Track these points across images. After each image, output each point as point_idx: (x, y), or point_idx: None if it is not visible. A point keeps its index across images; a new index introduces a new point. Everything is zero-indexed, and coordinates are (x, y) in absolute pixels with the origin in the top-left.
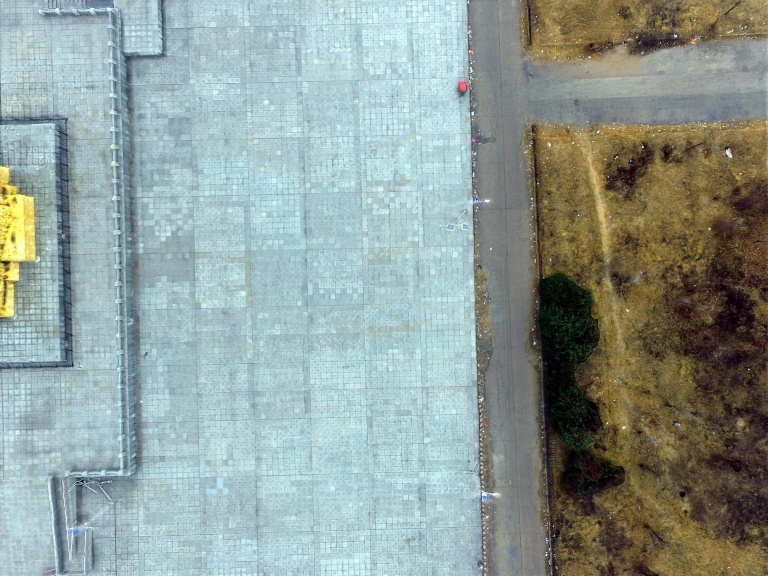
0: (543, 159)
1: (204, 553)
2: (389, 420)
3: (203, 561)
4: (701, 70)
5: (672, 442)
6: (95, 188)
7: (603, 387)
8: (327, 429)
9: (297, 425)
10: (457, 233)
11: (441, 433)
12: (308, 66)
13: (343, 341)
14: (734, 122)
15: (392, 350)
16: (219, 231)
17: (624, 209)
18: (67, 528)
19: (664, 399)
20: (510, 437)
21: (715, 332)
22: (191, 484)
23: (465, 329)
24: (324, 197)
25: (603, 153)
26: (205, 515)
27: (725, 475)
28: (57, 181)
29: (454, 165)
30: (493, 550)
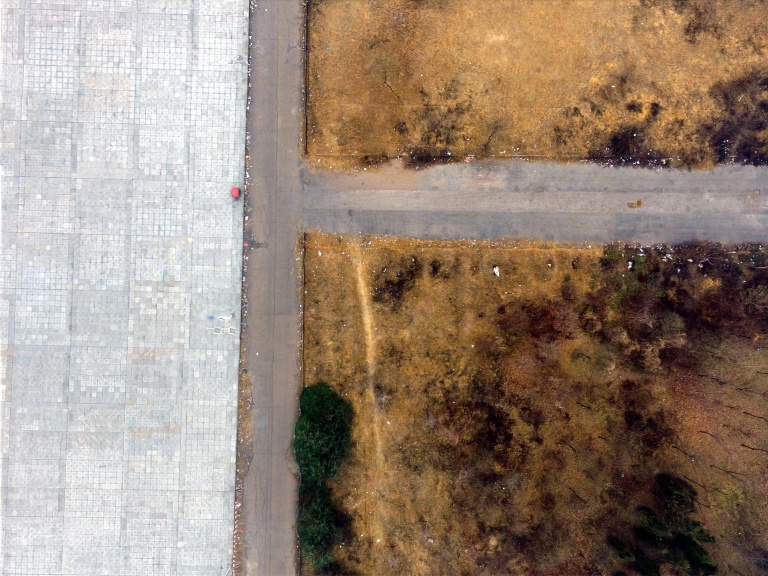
0: (312, 268)
1: None
2: (143, 522)
3: None
4: (474, 188)
5: (425, 558)
6: None
7: (360, 499)
8: (79, 529)
9: (49, 523)
10: (223, 337)
11: (195, 538)
12: (83, 163)
13: (102, 440)
14: (503, 241)
15: (151, 451)
16: None
17: (390, 322)
18: None
19: (420, 514)
20: (265, 545)
21: (473, 449)
22: None
23: (226, 434)
24: (91, 294)
25: (372, 265)
26: None
27: None
28: None
29: (224, 269)
30: None
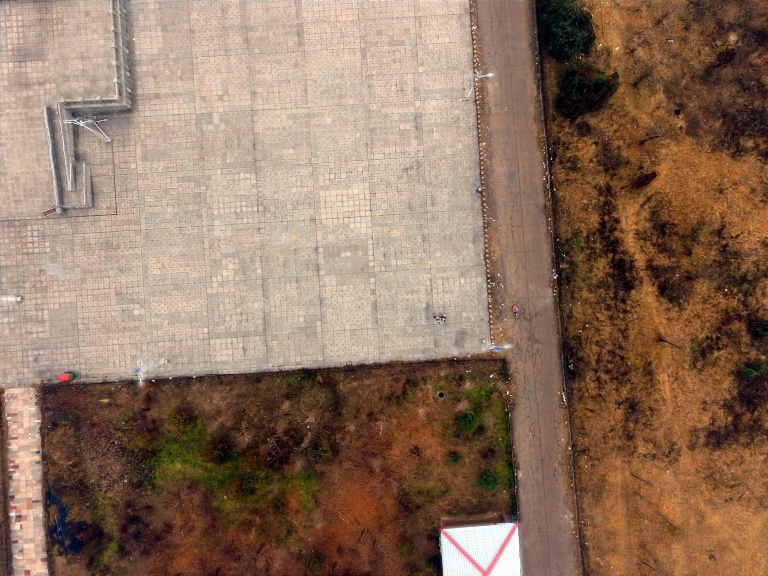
0: None
1: (203, 188)
2: (383, 51)
3: (203, 196)
4: None
5: (666, 60)
6: None
7: (595, 9)
8: (321, 61)
9: (291, 58)
10: None
11: (435, 62)
12: None
13: None
14: None
15: None
16: None
17: None
18: (65, 156)
19: (657, 18)
20: (504, 64)
21: None
22: (187, 120)
23: None
24: None
25: None
26: (203, 150)
27: (719, 90)
28: None
29: None
30: (491, 177)
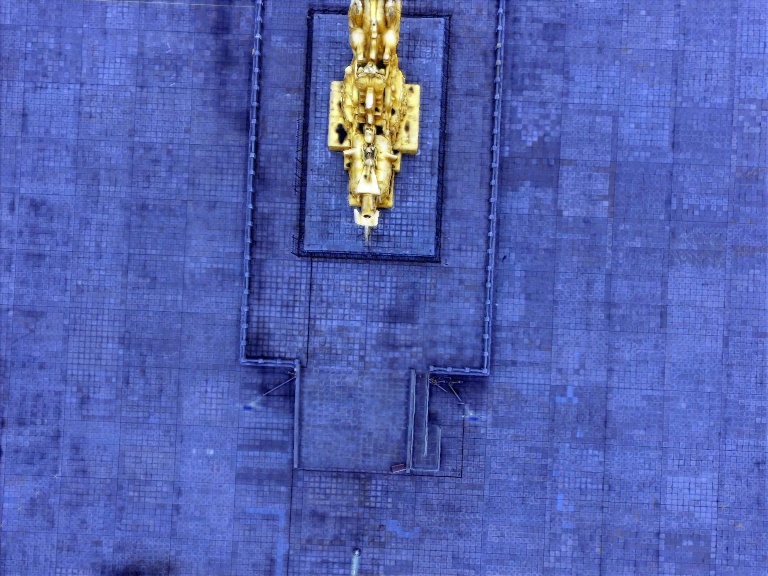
0: None
1: (550, 460)
2: (746, 341)
3: (549, 468)
4: None
5: None
6: (473, 87)
7: None
8: (682, 346)
9: (652, 339)
10: None
11: None
12: None
13: (704, 258)
14: None
15: (753, 271)
16: (586, 139)
17: None
18: None
19: None
20: None
21: None
22: (541, 391)
23: None
24: (694, 112)
25: None
26: (554, 423)
27: None
28: (442, 76)
29: None
30: None
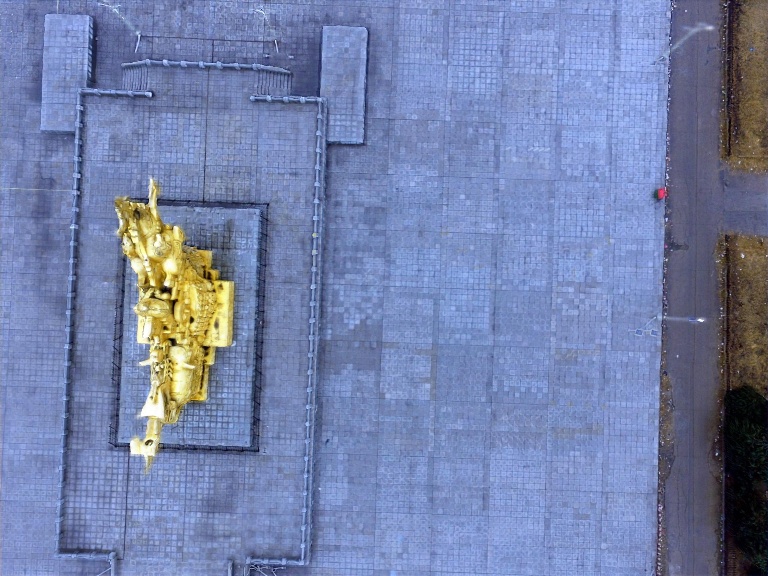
0: (736, 270)
1: None
2: (567, 523)
3: None
4: None
5: None
6: (292, 274)
7: None
8: (504, 528)
9: (474, 522)
10: (645, 339)
11: (619, 540)
12: (506, 163)
13: (525, 440)
14: None
15: (574, 452)
16: (408, 322)
17: None
18: None
19: None
20: (688, 548)
21: None
22: (365, 575)
23: (648, 436)
24: (514, 294)
25: None
26: None
27: None
28: (257, 266)
29: (646, 270)
30: None
